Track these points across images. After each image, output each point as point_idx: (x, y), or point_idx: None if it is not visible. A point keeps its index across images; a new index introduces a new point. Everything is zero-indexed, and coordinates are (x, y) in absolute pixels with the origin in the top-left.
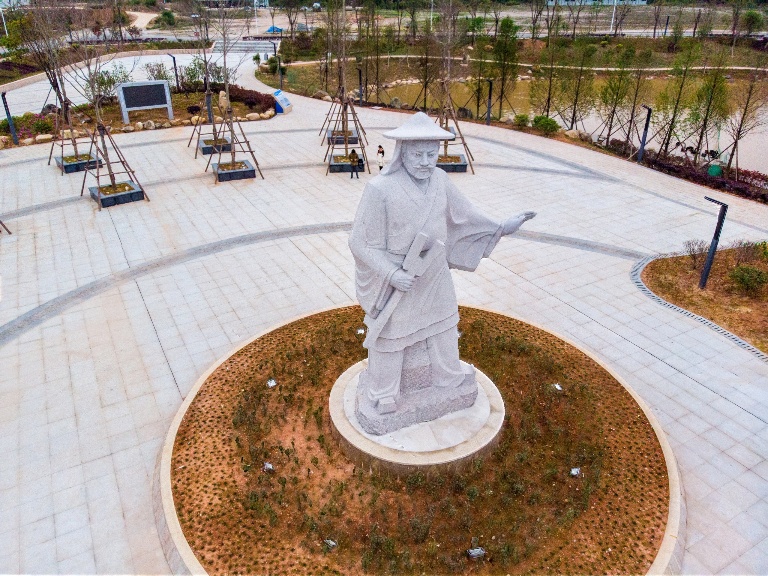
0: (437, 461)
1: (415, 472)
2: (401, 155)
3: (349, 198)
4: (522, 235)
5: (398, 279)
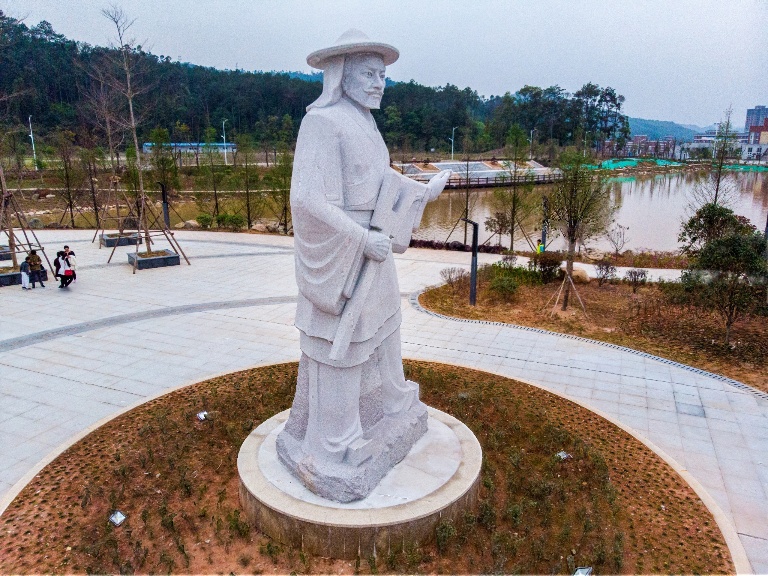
0: (457, 494)
1: (440, 522)
2: (342, 80)
3: (47, 305)
4: (290, 300)
5: (376, 241)
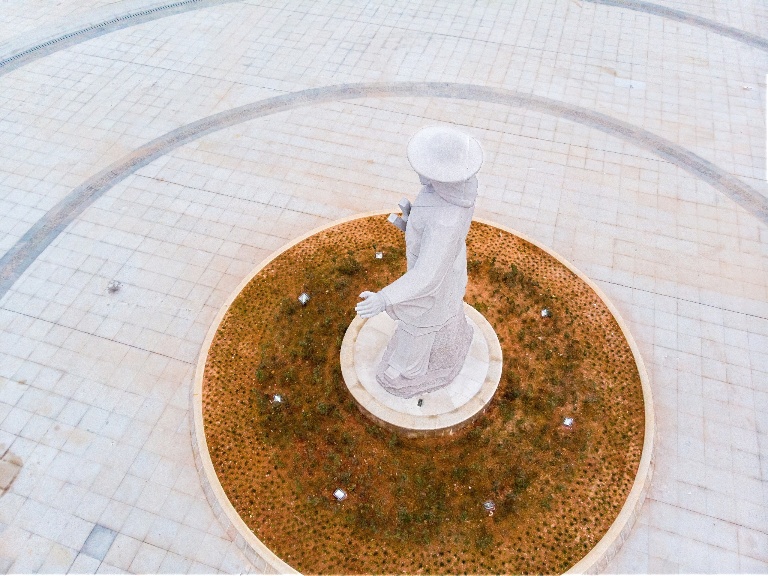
0: None
1: None
2: None
3: None
4: None
5: None
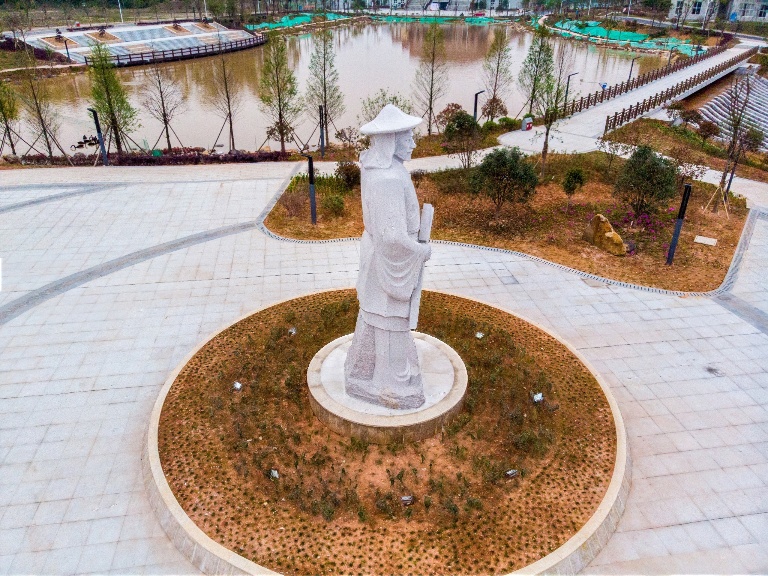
0: None
1: (467, 398)
2: None
3: None
4: (151, 254)
5: (428, 251)
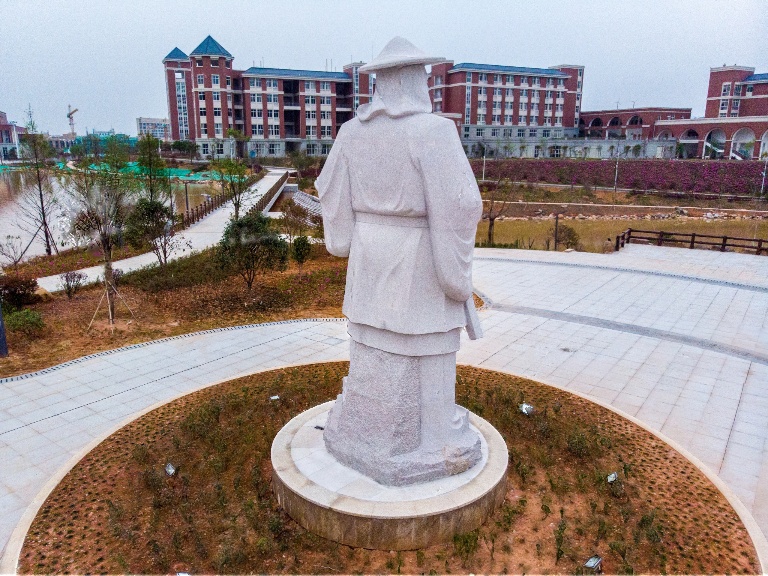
0: None
1: None
2: None
3: None
4: None
5: None
